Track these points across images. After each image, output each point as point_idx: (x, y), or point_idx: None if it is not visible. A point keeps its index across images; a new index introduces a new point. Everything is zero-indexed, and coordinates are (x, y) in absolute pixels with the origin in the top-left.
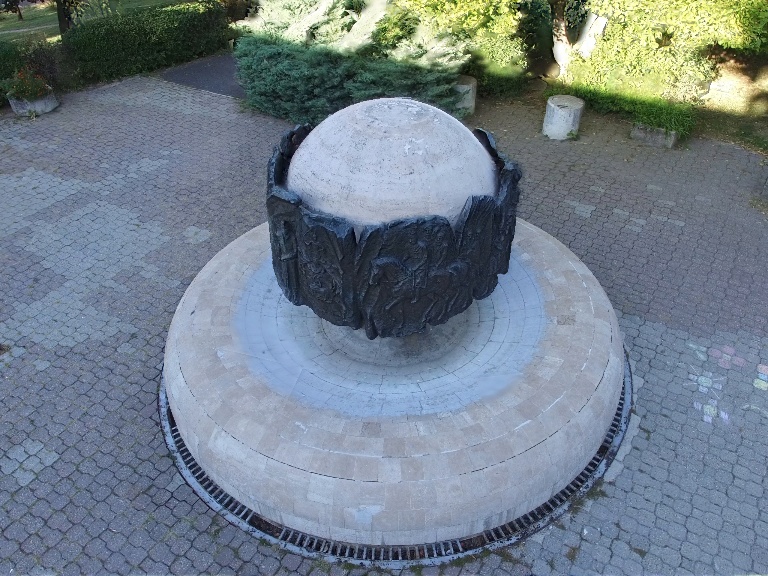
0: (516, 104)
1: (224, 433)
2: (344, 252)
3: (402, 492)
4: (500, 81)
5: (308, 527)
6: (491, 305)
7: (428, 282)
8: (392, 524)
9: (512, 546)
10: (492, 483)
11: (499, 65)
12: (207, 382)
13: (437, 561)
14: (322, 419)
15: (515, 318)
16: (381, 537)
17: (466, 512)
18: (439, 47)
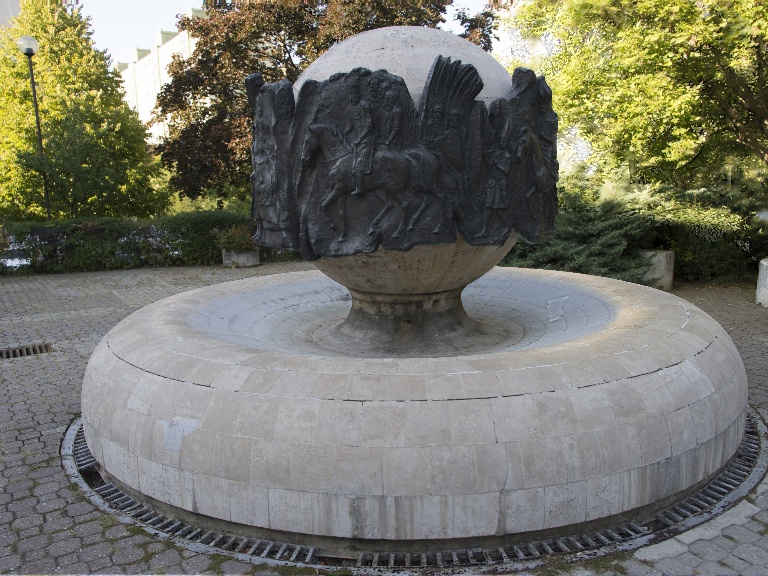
0: (731, 288)
1: (105, 344)
2: (277, 114)
3: (232, 404)
4: (709, 260)
5: (121, 463)
6: (540, 334)
7: (375, 166)
8: (205, 458)
9: None
10: (371, 426)
11: (707, 241)
12: (135, 315)
13: (258, 560)
14: (209, 340)
15: (560, 336)
16: (191, 488)
17: (316, 465)
18: (616, 196)
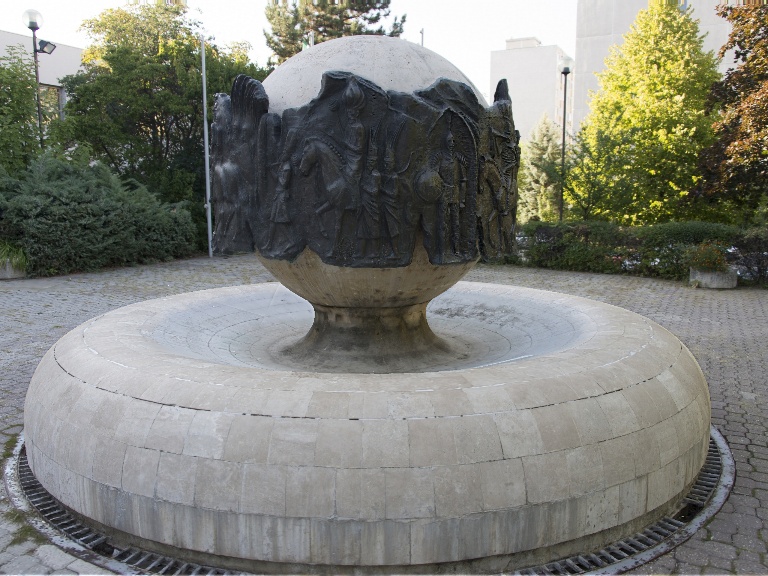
0: None
1: None
2: None
3: None
4: None
5: None
6: None
7: None
8: None
9: (2, 470)
10: None
11: None
12: None
13: None
14: (171, 303)
15: None
16: None
17: None
18: None
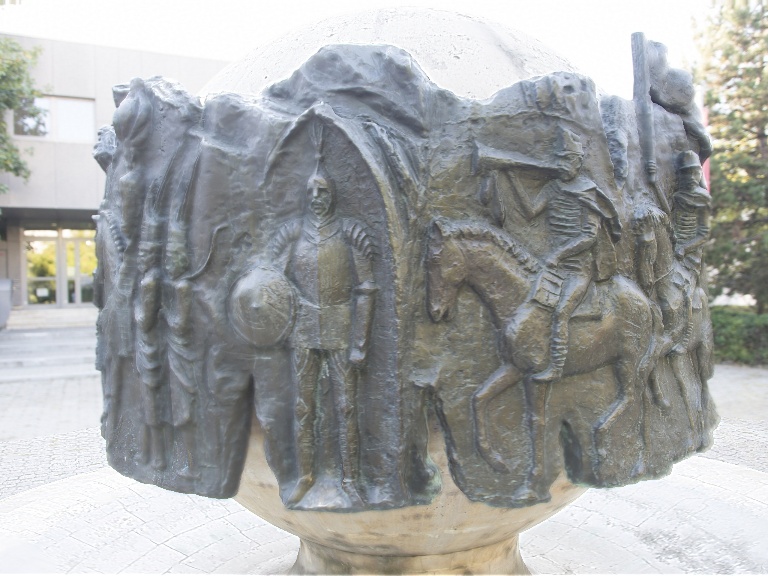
0: None
1: None
2: None
3: None
4: None
5: None
6: None
7: None
8: None
9: None
10: None
11: None
12: None
13: None
14: None
15: None
16: None
17: None
18: None
